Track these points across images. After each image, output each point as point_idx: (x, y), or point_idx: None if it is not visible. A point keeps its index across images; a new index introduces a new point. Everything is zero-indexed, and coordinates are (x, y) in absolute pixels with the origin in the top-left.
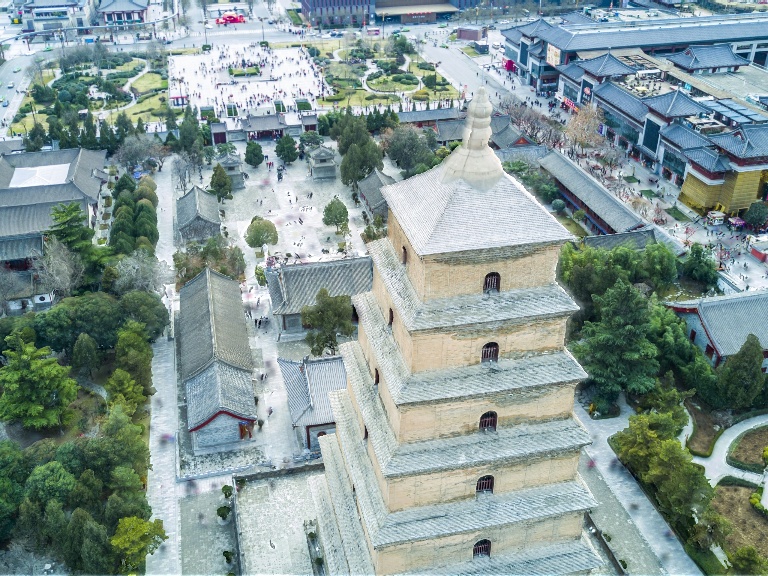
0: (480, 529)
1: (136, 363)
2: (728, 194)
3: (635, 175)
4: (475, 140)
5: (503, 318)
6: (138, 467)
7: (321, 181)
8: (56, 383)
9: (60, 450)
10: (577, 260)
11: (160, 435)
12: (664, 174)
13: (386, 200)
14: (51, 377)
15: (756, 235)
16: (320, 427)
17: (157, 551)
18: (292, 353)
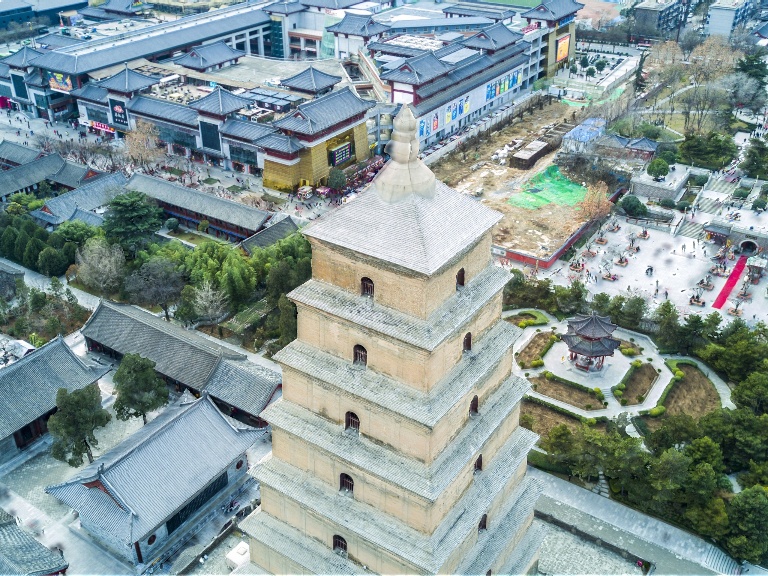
0: None
1: None
2: (308, 169)
3: (211, 176)
4: (415, 152)
5: (479, 306)
6: None
7: None
8: None
9: None
10: (253, 264)
11: None
12: (235, 168)
13: (325, 239)
14: None
15: (346, 196)
16: (148, 532)
17: None
18: (28, 481)
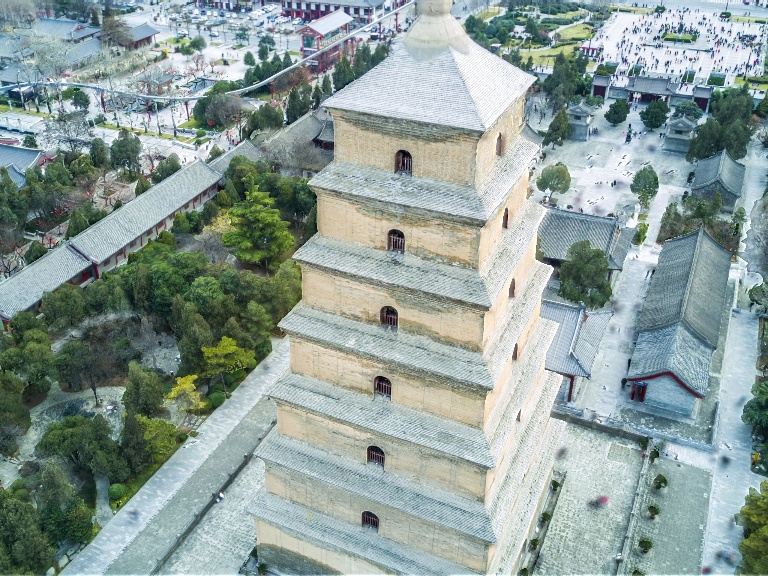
0: (371, 431)
1: None
2: None
3: None
4: (422, 2)
5: (401, 202)
6: (281, 314)
7: (669, 154)
8: (269, 229)
9: (226, 273)
10: None
11: None
12: None
13: None
14: (266, 222)
15: None
16: None
17: (253, 382)
18: None
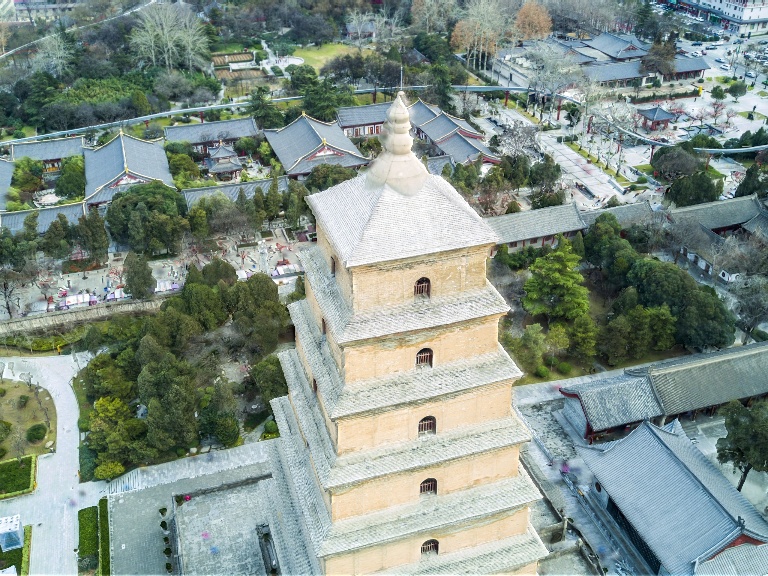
0: None
1: (613, 327)
2: None
3: None
4: None
5: None
6: None
7: None
8: (559, 291)
9: None
10: None
11: (568, 385)
12: None
13: None
14: (557, 283)
15: None
16: None
17: None
18: None
